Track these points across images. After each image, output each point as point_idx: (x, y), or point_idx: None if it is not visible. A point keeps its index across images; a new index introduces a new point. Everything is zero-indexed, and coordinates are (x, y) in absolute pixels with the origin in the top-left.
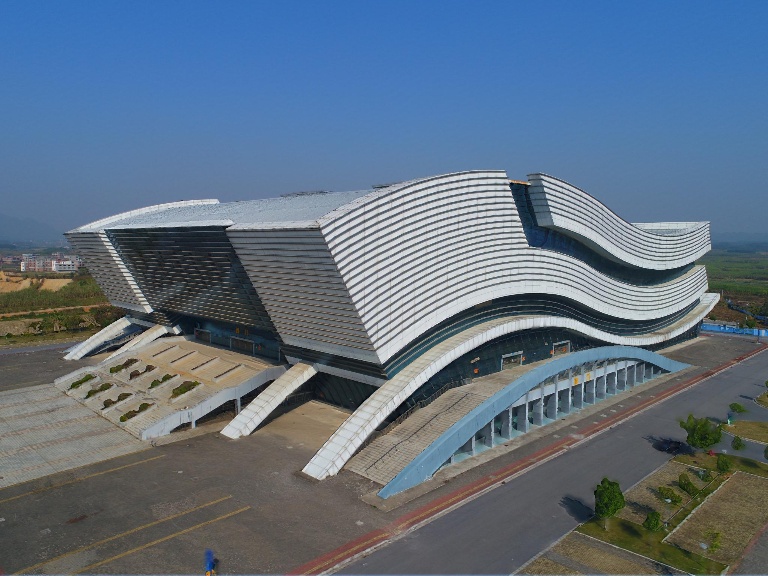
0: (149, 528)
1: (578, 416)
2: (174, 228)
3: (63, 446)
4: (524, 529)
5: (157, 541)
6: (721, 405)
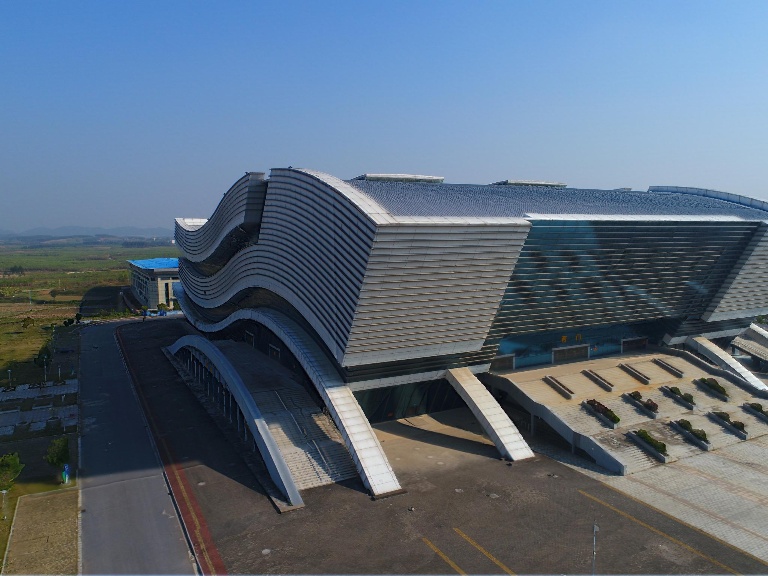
0: None
1: None
2: (692, 222)
3: None
4: None
5: None
6: None
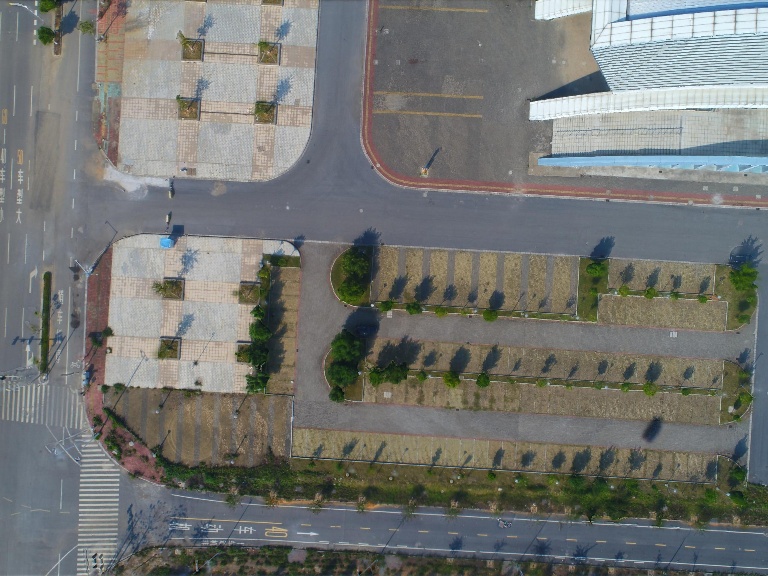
0: (434, 99)
1: (764, 180)
2: None
3: None
4: (564, 238)
5: (431, 113)
6: None
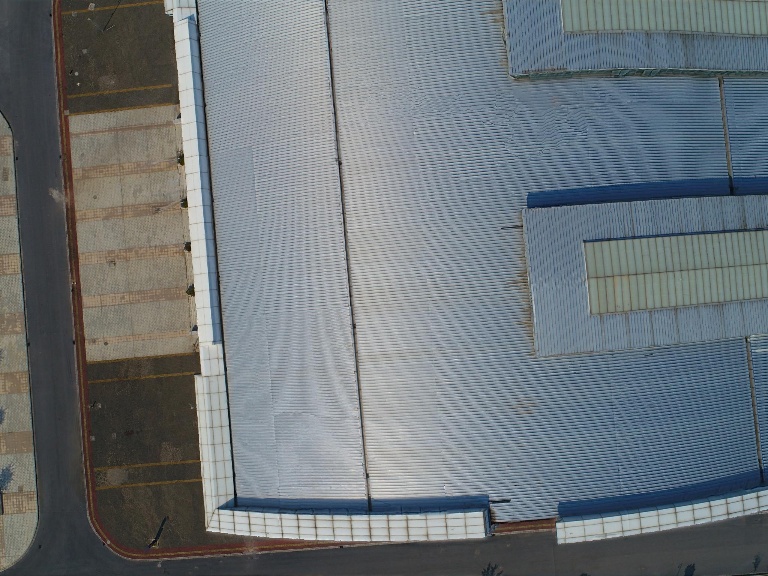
0: (154, 468)
1: None
2: None
3: (146, 310)
4: None
5: (153, 484)
6: (637, 567)
